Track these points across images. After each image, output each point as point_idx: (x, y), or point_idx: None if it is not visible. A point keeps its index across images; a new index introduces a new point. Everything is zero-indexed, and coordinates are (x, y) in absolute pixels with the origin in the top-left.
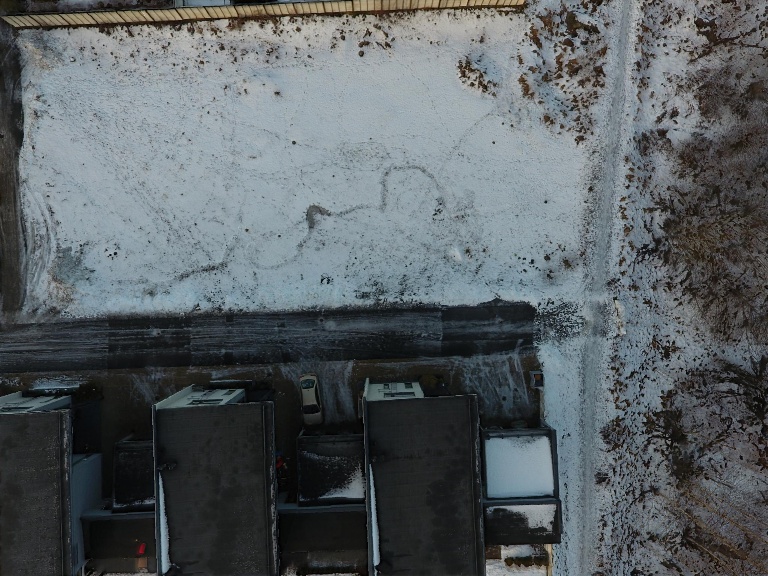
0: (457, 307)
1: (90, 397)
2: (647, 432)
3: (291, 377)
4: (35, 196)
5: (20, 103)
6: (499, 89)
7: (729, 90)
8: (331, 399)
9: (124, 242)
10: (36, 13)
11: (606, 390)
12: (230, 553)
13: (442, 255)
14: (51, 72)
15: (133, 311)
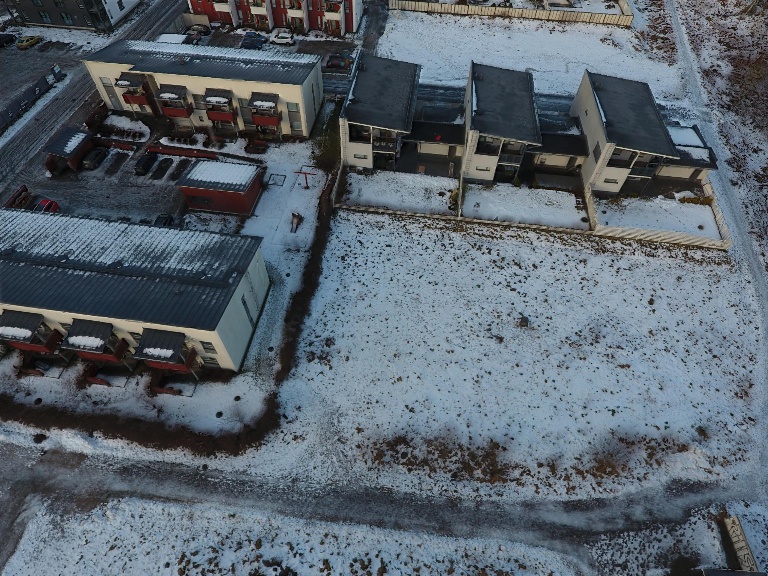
0: None
1: None
2: (758, 182)
3: None
4: (384, 48)
5: (384, 26)
6: (623, 48)
7: (745, 61)
8: None
9: (427, 66)
10: (406, 1)
11: (721, 143)
12: (511, 113)
13: None
14: (402, 21)
15: (430, 83)
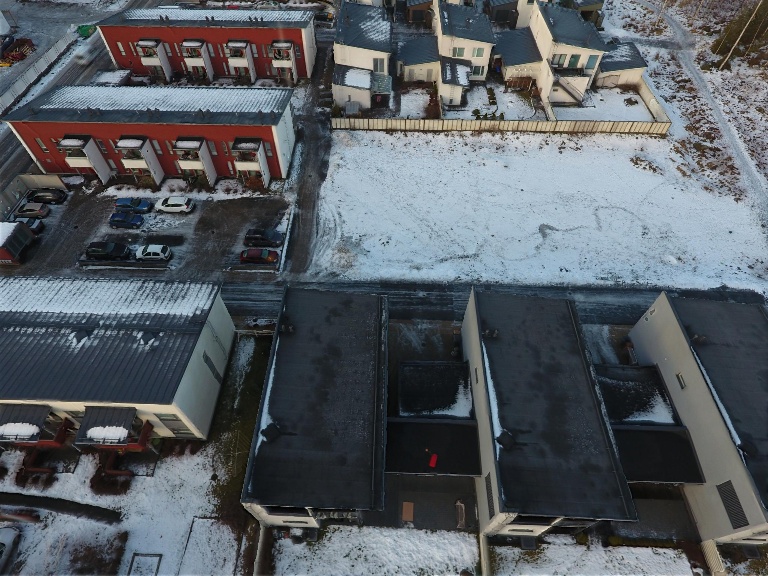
0: (690, 290)
1: None
2: None
3: None
4: (329, 206)
5: (327, 161)
6: (664, 172)
7: None
8: (595, 355)
9: (395, 236)
10: (355, 118)
11: None
12: (563, 427)
13: (659, 260)
14: (351, 149)
15: (402, 278)
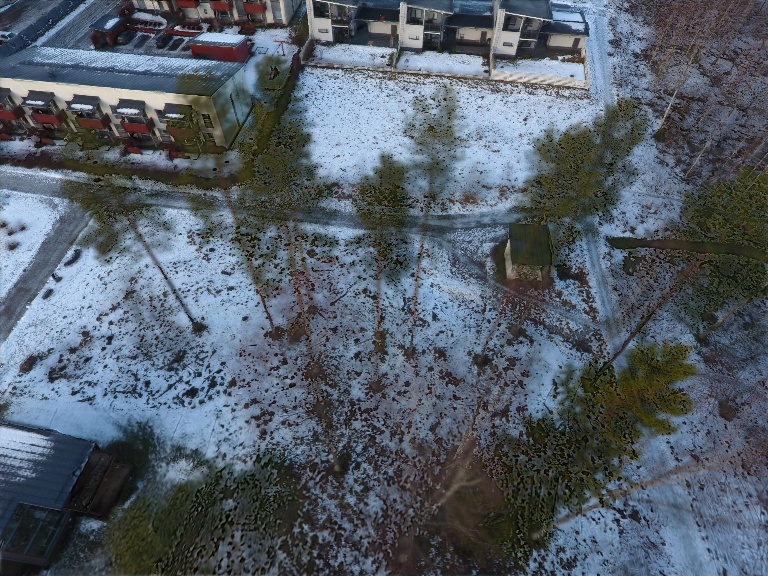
0: None
1: None
2: None
3: (454, 10)
4: None
5: None
6: None
7: None
8: None
9: None
10: None
11: (608, 30)
12: None
13: None
14: None
15: None
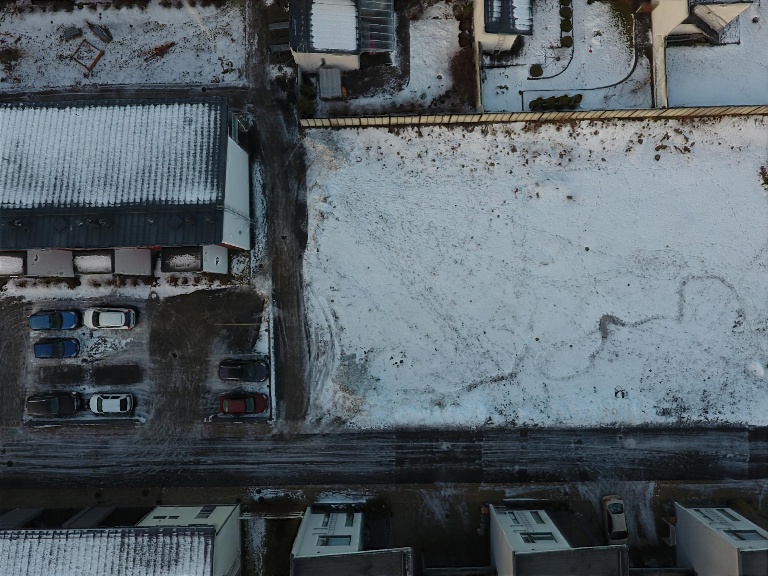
0: (765, 427)
1: (381, 514)
2: None
3: (589, 497)
4: (319, 300)
5: (305, 204)
6: None
7: None
8: (631, 521)
9: (410, 350)
10: (337, 116)
11: None
12: None
13: (742, 369)
14: (338, 172)
15: (422, 423)
